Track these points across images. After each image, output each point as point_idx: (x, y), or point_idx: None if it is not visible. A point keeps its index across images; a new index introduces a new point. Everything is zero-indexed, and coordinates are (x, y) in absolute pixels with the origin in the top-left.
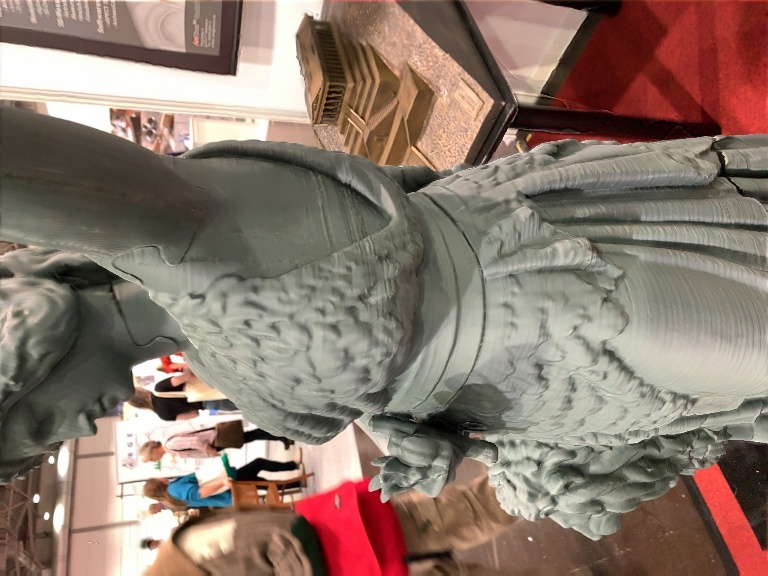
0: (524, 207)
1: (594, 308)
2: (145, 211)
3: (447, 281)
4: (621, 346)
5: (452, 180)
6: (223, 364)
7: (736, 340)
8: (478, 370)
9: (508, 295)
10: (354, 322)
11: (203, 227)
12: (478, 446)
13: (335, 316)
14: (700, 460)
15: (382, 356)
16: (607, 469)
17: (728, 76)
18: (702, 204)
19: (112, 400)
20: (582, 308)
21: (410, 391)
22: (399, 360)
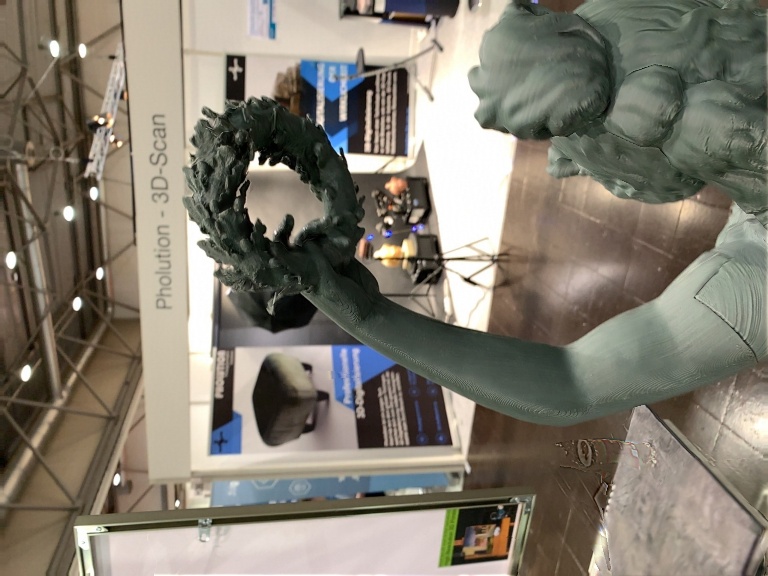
0: None
1: None
2: None
3: None
4: None
5: None
6: None
7: None
8: None
9: None
10: None
11: None
12: None
13: None
14: None
15: None
16: None
17: None
18: None
19: None
20: None
21: None
22: None
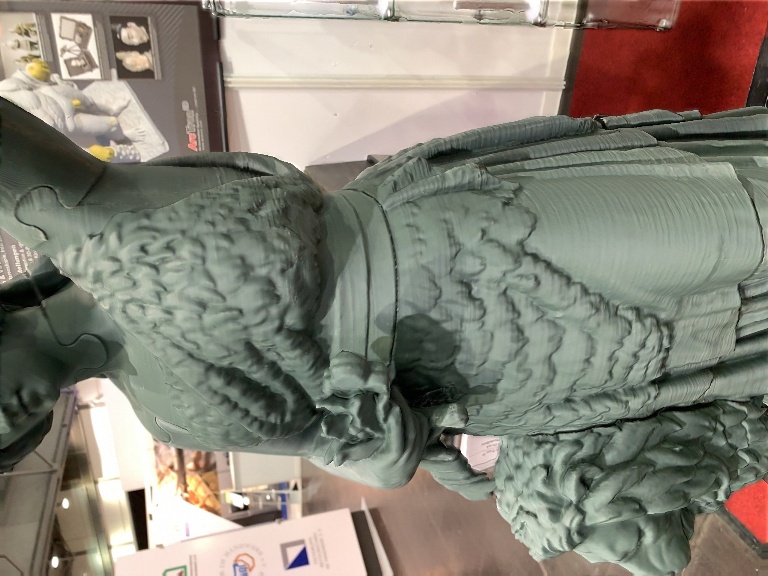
0: None
1: (496, 211)
2: (36, 148)
3: (348, 217)
4: (540, 245)
5: None
6: (134, 317)
7: (652, 212)
8: (403, 298)
9: (409, 216)
10: (245, 230)
11: (101, 183)
12: (442, 407)
13: (225, 225)
14: (749, 452)
15: (282, 262)
16: (625, 454)
17: None
18: (585, 138)
19: (32, 395)
20: (484, 212)
21: (343, 342)
22: (307, 278)
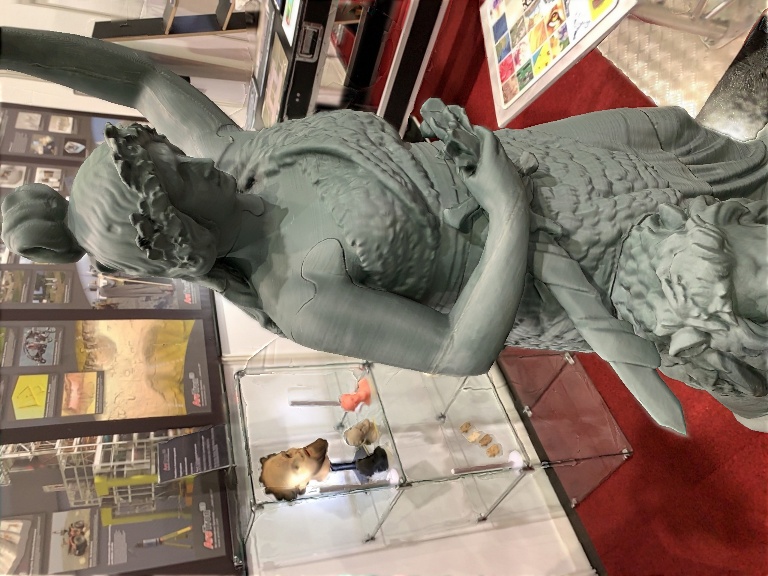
0: None
1: None
2: None
3: None
4: None
5: None
6: None
7: None
8: None
9: None
10: None
11: None
12: None
13: None
14: None
15: None
16: None
17: (763, 565)
18: None
19: None
20: None
21: None
22: None
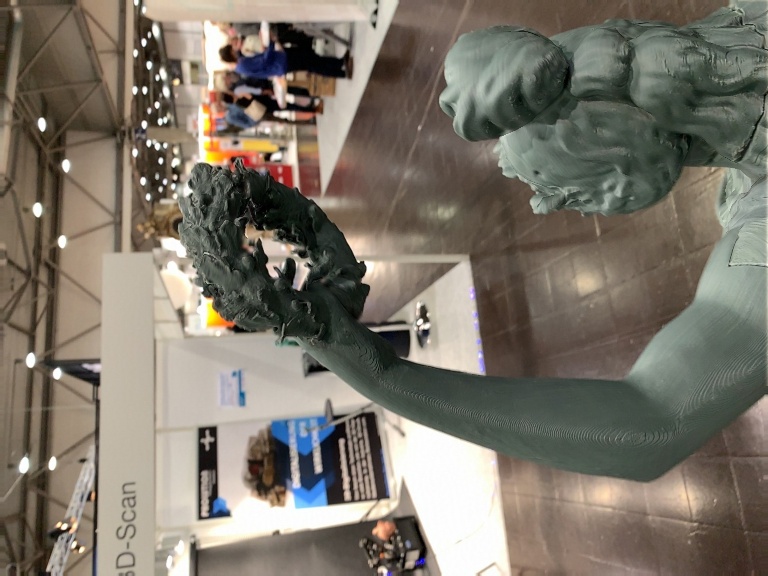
0: None
1: None
2: None
3: None
4: None
5: None
6: None
7: None
8: None
9: None
10: None
11: None
12: None
13: None
14: None
15: None
16: None
17: None
18: None
19: None
20: None
21: None
22: None
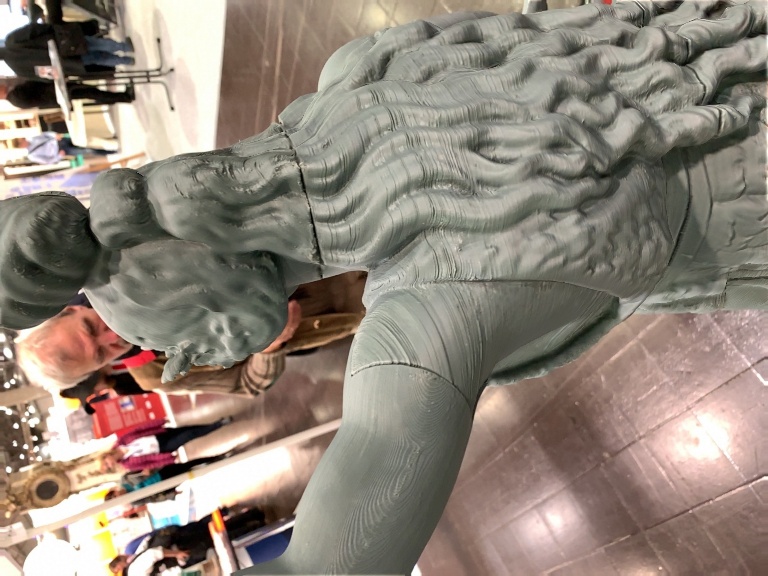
0: (723, 286)
1: None
2: None
3: None
4: None
5: (729, 199)
6: None
7: None
8: None
9: None
10: None
11: None
12: None
13: None
14: None
15: None
16: None
17: None
18: None
19: None
20: None
21: None
22: None
